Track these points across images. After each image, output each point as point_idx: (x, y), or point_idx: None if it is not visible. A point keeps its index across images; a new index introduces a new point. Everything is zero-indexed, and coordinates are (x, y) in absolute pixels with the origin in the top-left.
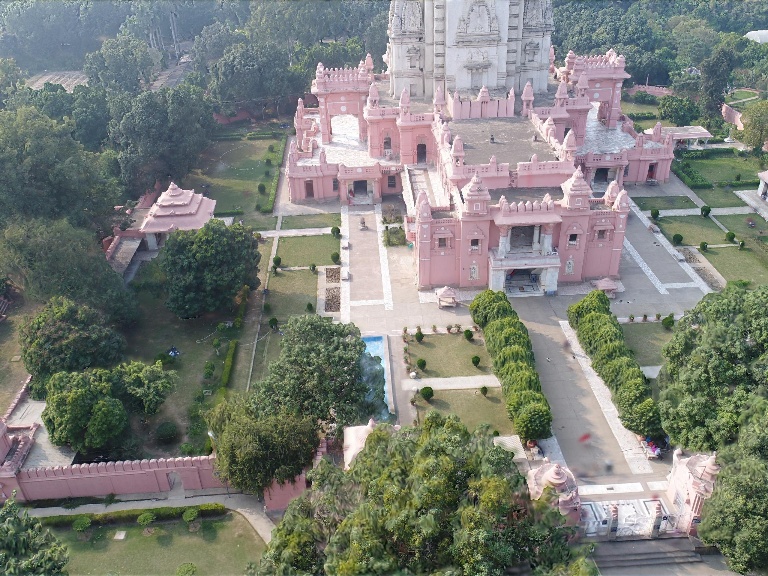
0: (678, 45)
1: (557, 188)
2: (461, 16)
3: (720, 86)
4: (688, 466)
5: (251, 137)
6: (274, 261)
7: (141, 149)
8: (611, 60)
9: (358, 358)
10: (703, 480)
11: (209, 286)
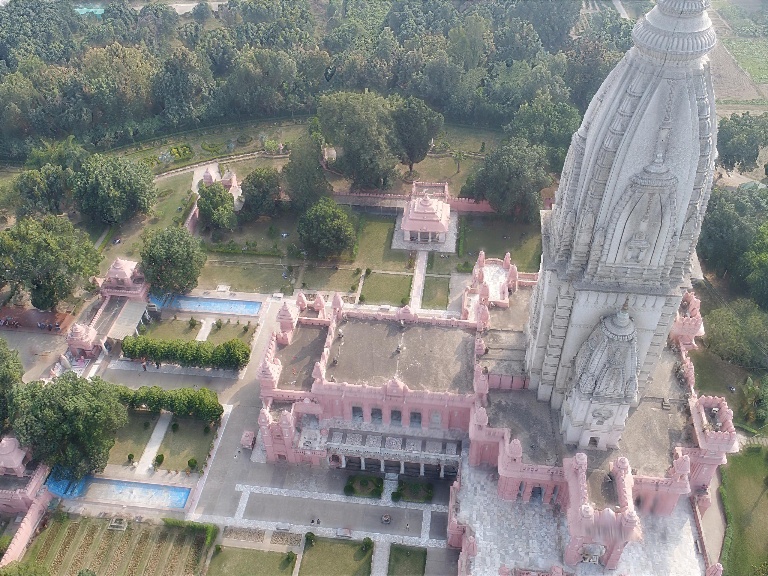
0: None
1: None
2: None
3: None
4: None
5: None
6: None
7: (476, 172)
8: None
9: (153, 253)
10: None
11: None
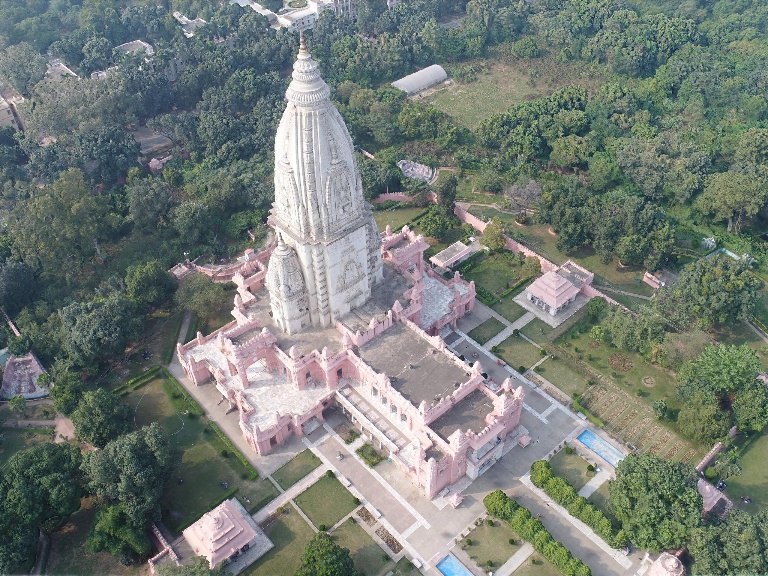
0: (372, 129)
1: (475, 392)
2: (339, 275)
3: None
4: (664, 567)
5: (136, 387)
6: (322, 530)
7: (151, 498)
8: (410, 235)
9: None
10: (673, 571)
11: None
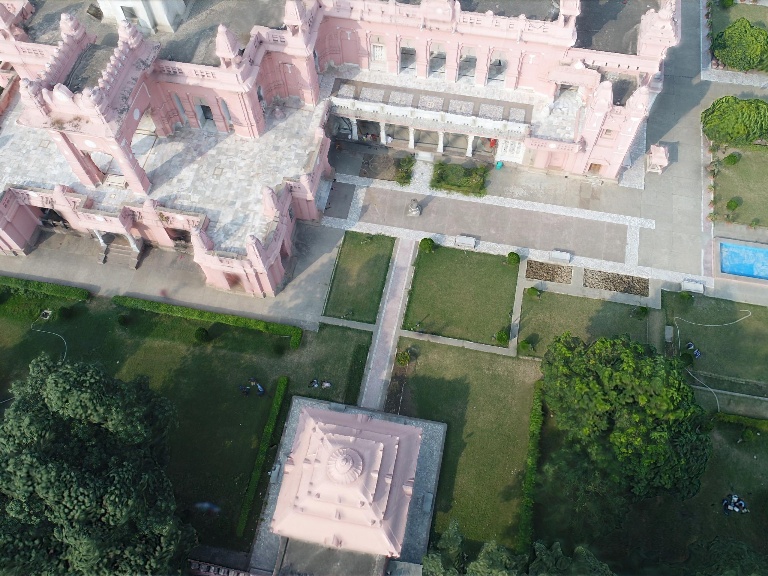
0: None
1: None
2: None
3: None
4: None
5: None
6: None
7: (170, 525)
8: None
9: None
10: None
11: (699, 418)
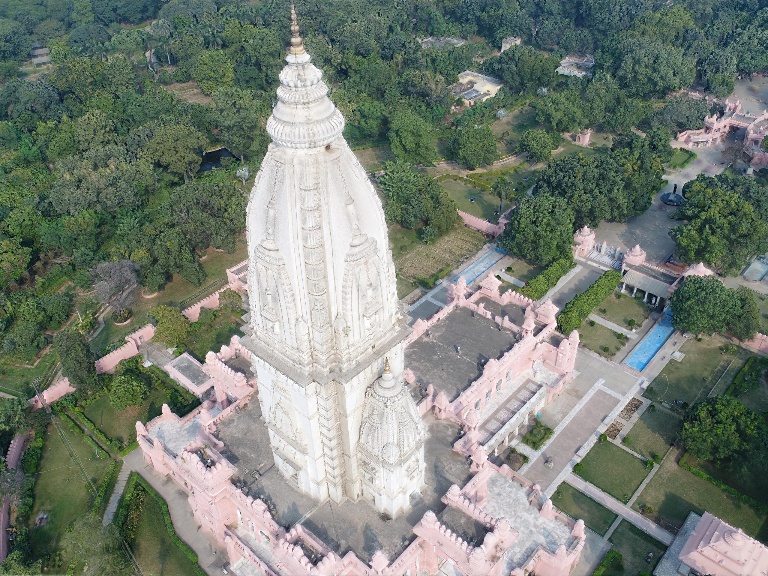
0: None
1: None
2: None
3: None
4: (589, 236)
5: None
6: None
7: None
8: None
9: None
10: None
11: None
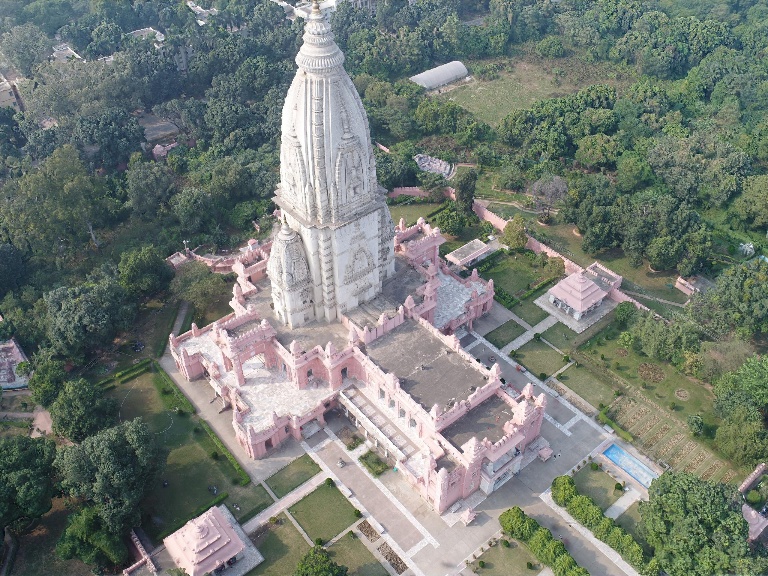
0: (388, 122)
1: (492, 398)
2: (347, 264)
3: (472, 196)
4: None
5: (124, 380)
6: (318, 544)
7: (129, 501)
8: (426, 228)
9: None
10: None
11: None
